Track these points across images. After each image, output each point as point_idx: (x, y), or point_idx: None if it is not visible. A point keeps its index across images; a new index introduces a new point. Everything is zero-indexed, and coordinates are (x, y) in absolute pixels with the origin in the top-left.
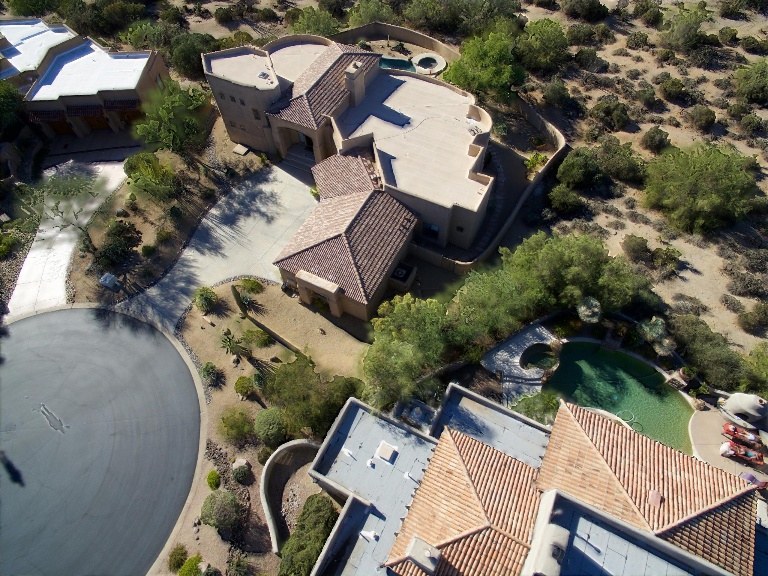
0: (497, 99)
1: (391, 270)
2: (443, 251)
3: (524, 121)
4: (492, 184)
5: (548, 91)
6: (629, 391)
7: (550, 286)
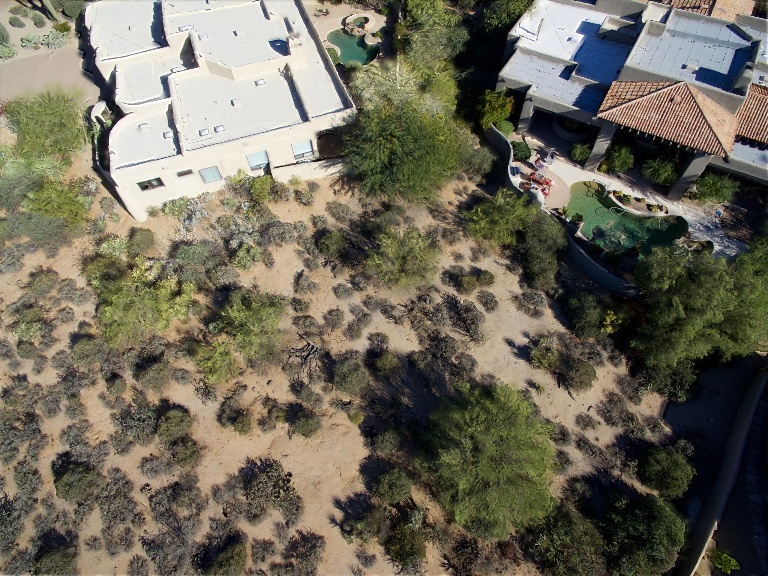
0: None
1: None
2: None
3: None
4: None
5: None
6: None
7: None
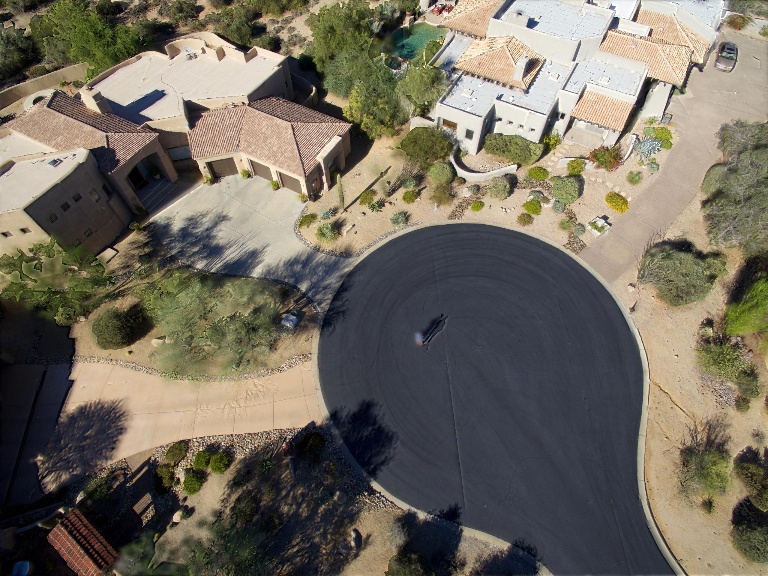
0: None
1: None
2: None
3: None
4: None
5: (141, 31)
6: (411, 45)
7: None
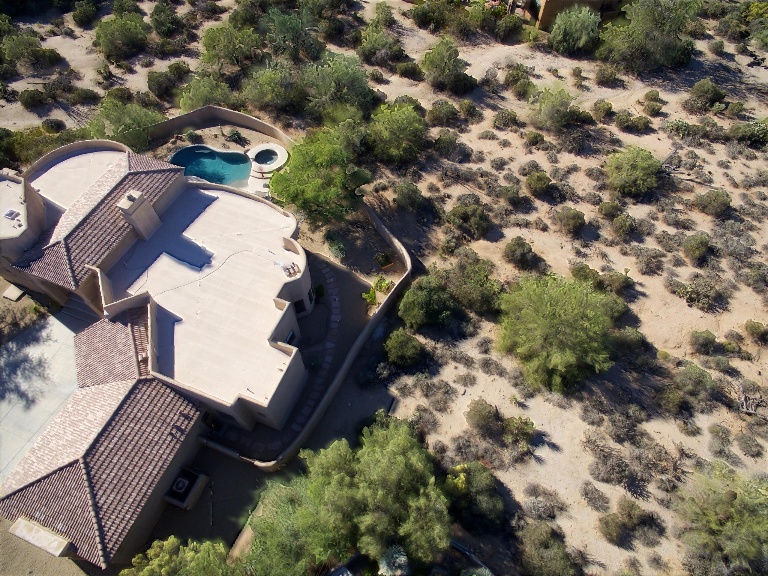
0: (343, 202)
1: (166, 485)
2: (249, 435)
3: (372, 231)
4: (298, 354)
5: (398, 193)
6: None
7: (343, 533)
